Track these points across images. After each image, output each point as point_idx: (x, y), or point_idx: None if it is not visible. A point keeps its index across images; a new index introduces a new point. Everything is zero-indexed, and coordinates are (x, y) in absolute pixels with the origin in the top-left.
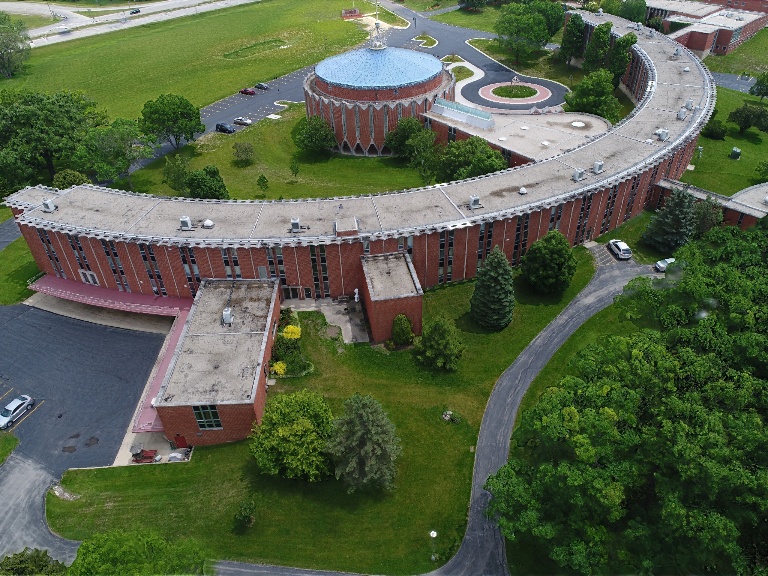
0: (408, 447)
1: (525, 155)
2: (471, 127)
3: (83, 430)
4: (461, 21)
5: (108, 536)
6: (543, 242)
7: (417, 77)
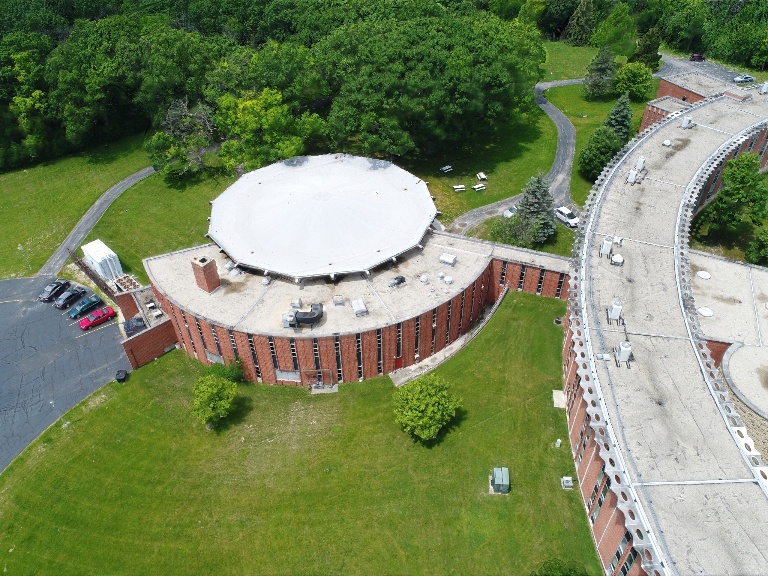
0: (589, 106)
1: (766, 273)
2: None
3: None
4: None
5: (625, 7)
6: None
7: None
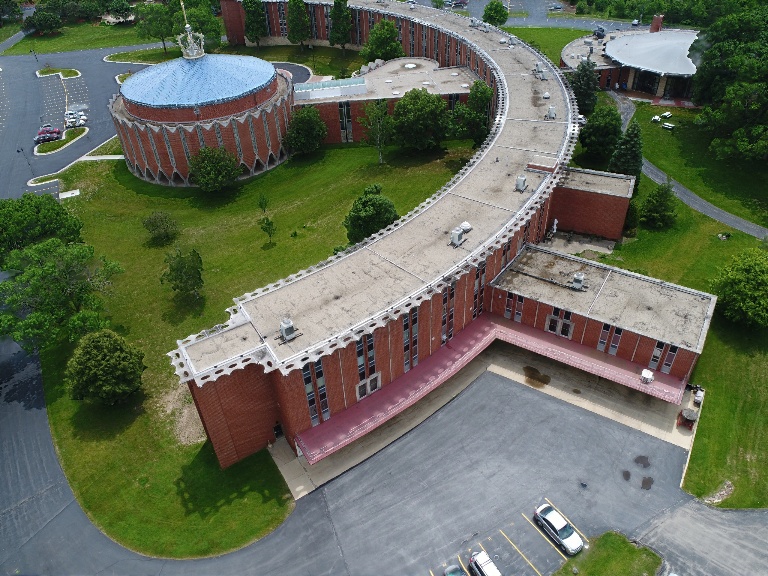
0: None
1: None
2: (354, 96)
3: (619, 467)
4: (53, 47)
5: None
6: (608, 117)
7: (268, 70)
